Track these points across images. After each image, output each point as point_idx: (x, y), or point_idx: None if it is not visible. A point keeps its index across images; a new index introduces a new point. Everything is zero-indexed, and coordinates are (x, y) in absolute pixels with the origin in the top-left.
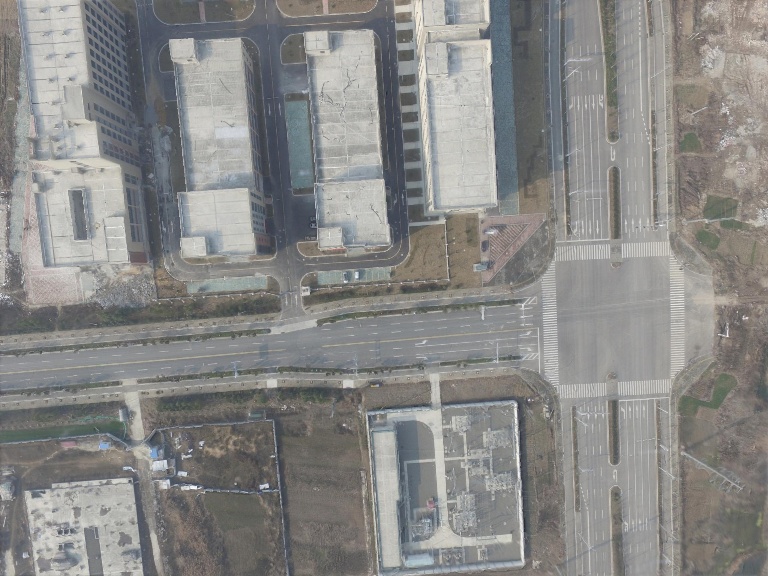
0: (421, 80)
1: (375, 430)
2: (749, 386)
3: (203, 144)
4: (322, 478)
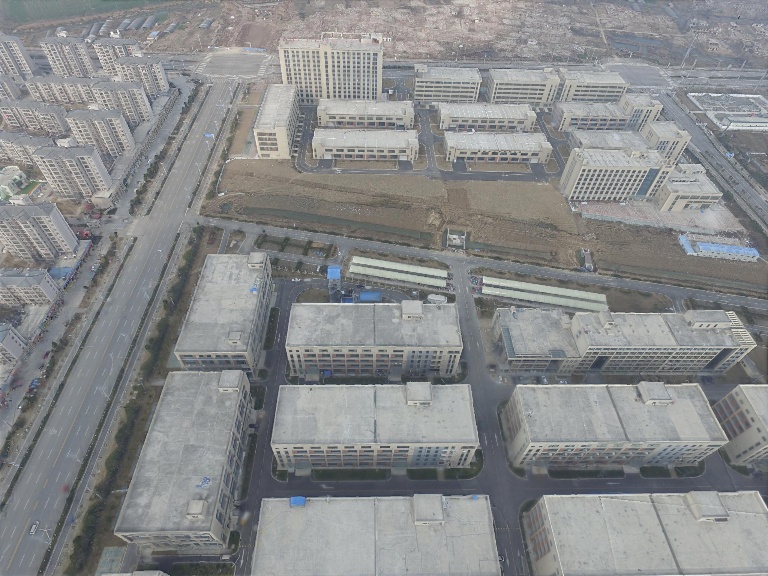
0: (570, 94)
1: (729, 121)
2: (645, 54)
3: (626, 144)
4: (765, 143)
